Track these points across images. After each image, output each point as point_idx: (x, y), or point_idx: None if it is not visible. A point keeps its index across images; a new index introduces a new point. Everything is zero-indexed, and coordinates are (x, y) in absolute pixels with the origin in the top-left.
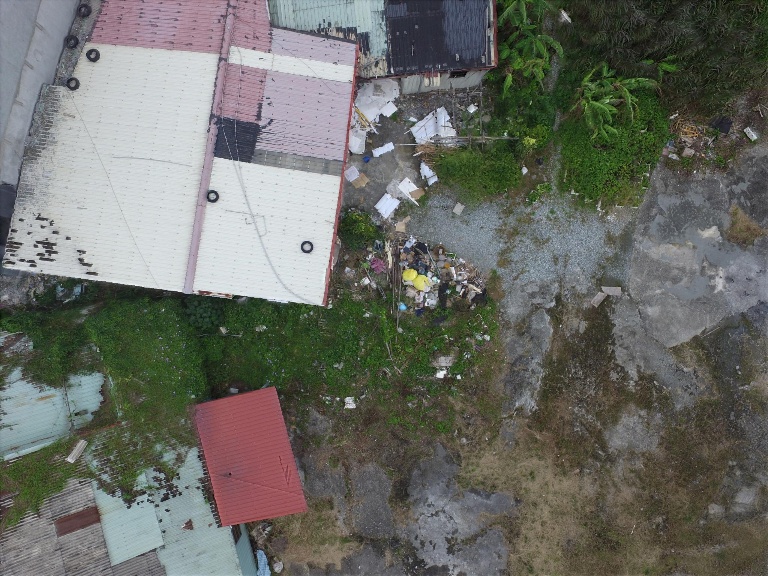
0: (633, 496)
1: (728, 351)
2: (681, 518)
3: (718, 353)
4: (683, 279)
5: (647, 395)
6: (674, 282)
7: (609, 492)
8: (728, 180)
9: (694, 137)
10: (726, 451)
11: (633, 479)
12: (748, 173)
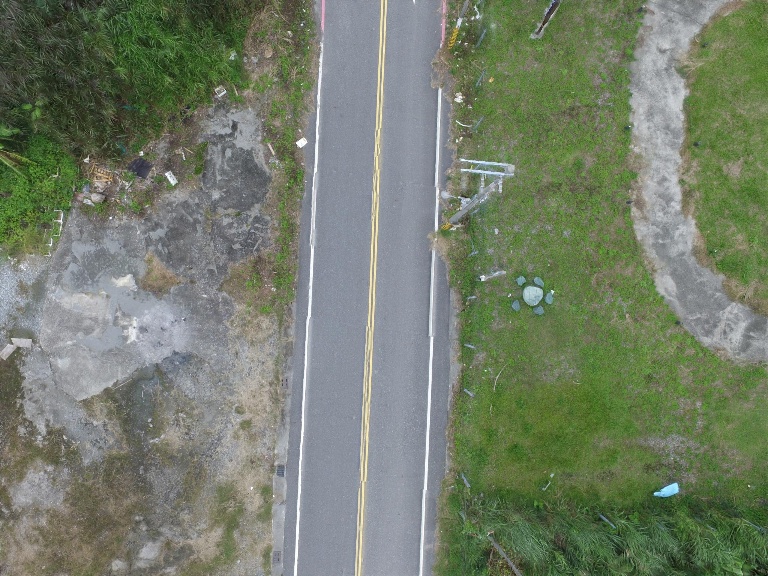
0: (34, 554)
1: (141, 403)
2: (84, 575)
3: (130, 406)
4: (95, 330)
5: (55, 450)
6: (86, 333)
7: (9, 551)
8: (146, 226)
9: (109, 182)
10: (133, 506)
11: (36, 537)
12: (167, 219)
